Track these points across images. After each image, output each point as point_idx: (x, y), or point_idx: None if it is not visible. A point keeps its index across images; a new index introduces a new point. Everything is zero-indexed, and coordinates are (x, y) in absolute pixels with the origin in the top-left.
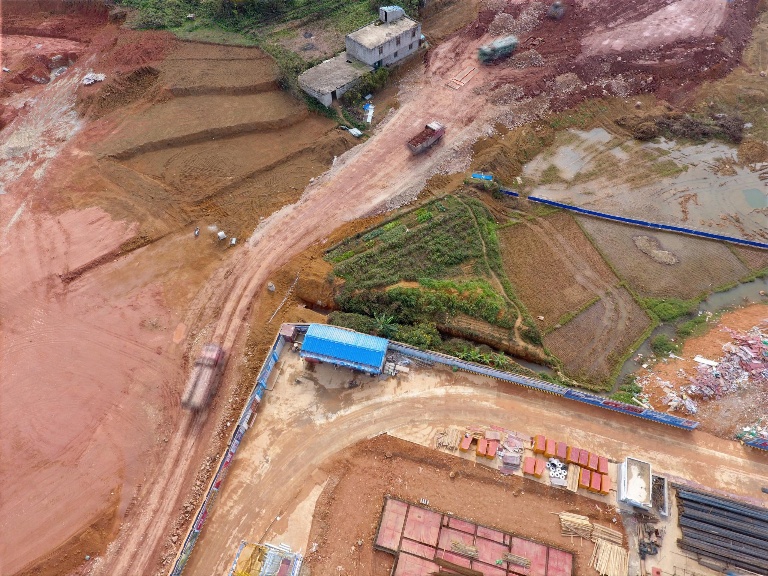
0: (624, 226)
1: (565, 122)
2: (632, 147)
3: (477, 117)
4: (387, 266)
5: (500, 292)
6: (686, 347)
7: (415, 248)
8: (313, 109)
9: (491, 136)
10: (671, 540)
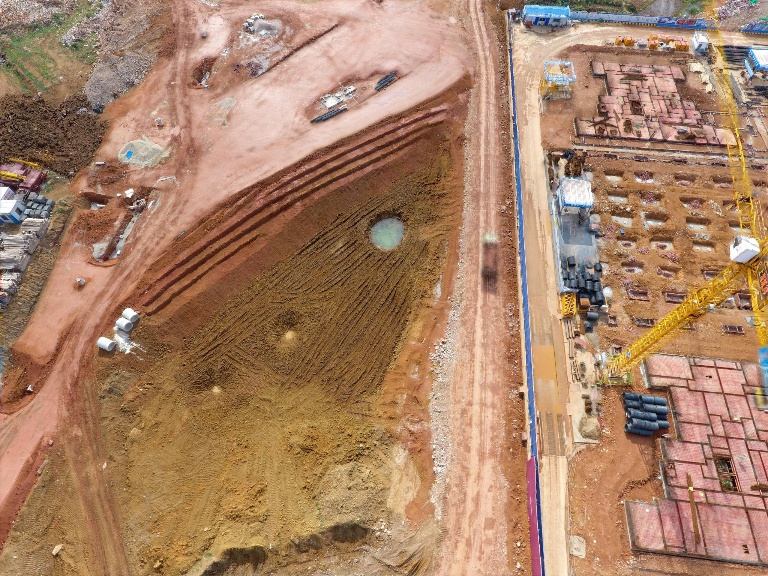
0: None
1: None
2: None
3: None
4: None
5: None
6: (706, 9)
7: None
8: None
9: None
10: (720, 60)
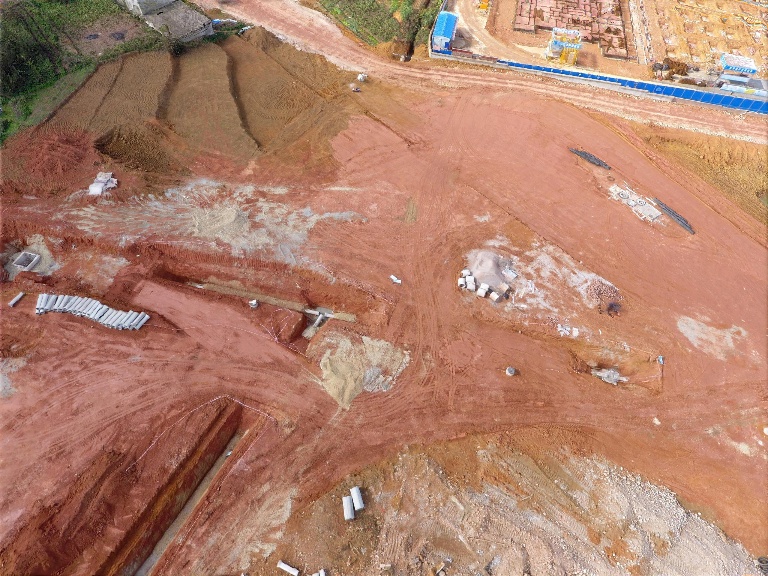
0: None
1: None
2: None
3: None
4: None
5: None
6: None
7: None
8: (215, 41)
9: None
10: None
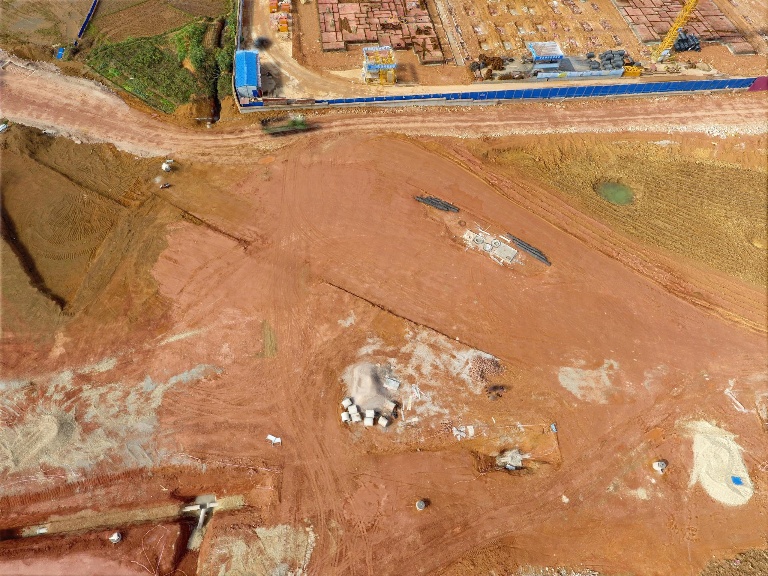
0: None
1: None
2: None
3: None
4: None
5: None
6: None
7: None
8: None
9: None
10: None
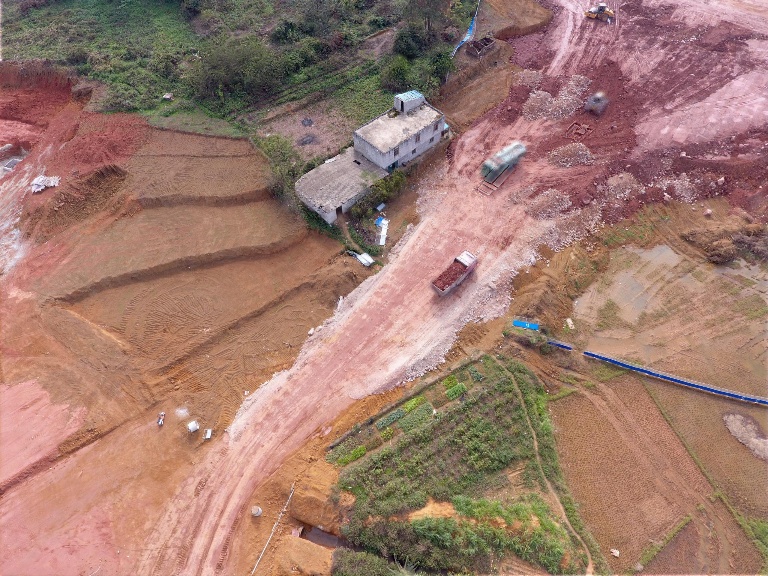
0: (709, 398)
1: (621, 237)
2: (706, 274)
3: (516, 237)
4: (409, 473)
5: (561, 517)
6: None
7: (445, 443)
8: (313, 227)
9: (534, 264)
10: None
